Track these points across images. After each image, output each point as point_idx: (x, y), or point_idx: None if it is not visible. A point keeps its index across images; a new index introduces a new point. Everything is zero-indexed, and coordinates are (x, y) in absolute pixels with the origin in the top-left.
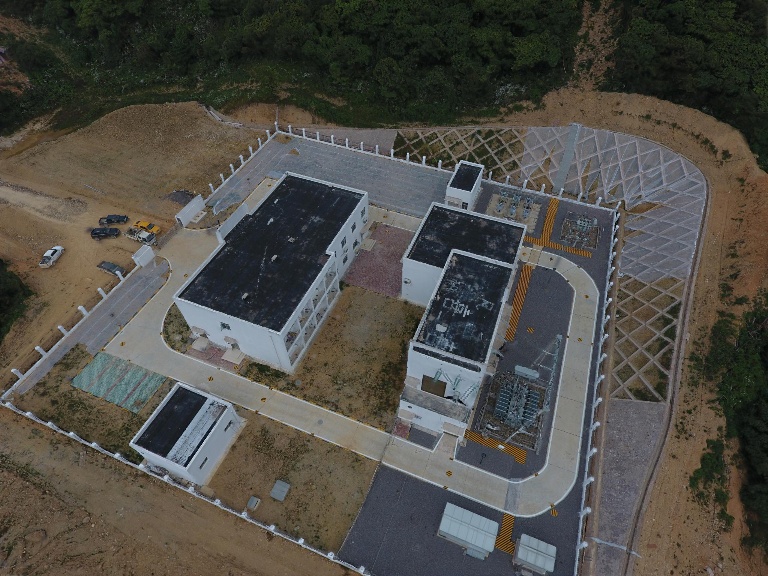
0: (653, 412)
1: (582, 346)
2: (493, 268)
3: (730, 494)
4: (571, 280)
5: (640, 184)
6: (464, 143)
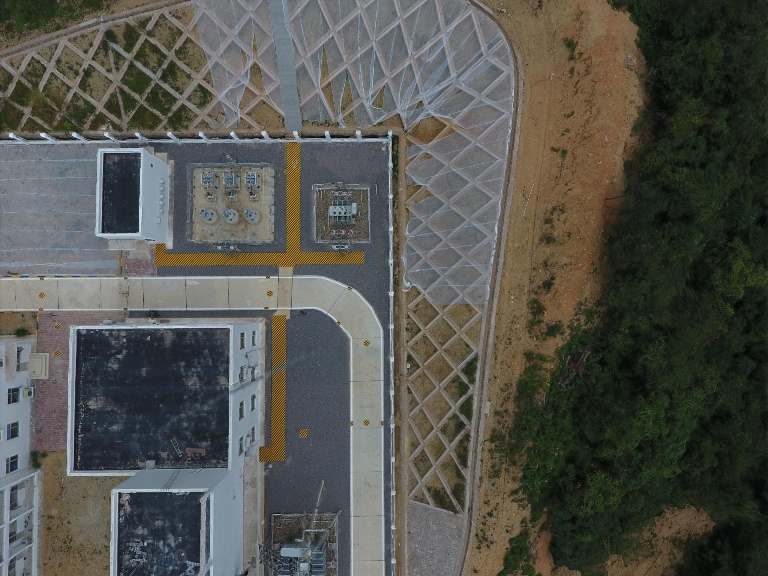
0: (452, 526)
1: (370, 432)
2: (186, 494)
3: (537, 562)
4: (342, 320)
5: (416, 80)
6: (98, 69)
